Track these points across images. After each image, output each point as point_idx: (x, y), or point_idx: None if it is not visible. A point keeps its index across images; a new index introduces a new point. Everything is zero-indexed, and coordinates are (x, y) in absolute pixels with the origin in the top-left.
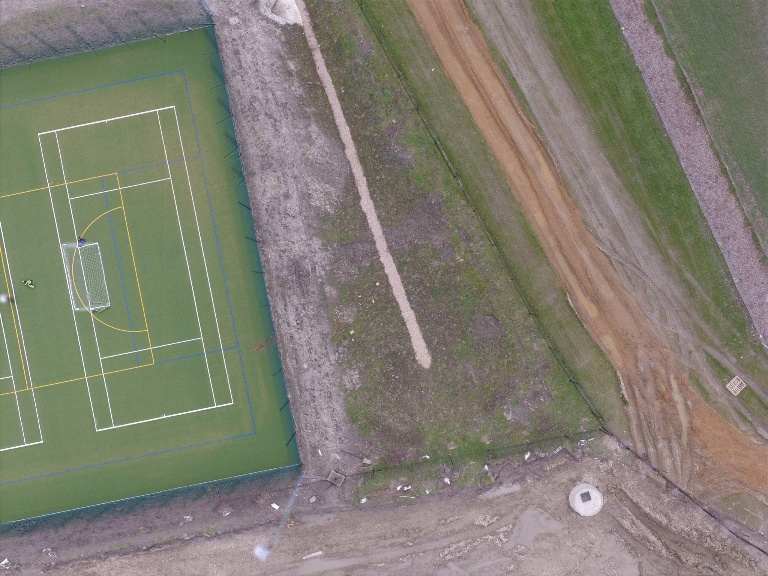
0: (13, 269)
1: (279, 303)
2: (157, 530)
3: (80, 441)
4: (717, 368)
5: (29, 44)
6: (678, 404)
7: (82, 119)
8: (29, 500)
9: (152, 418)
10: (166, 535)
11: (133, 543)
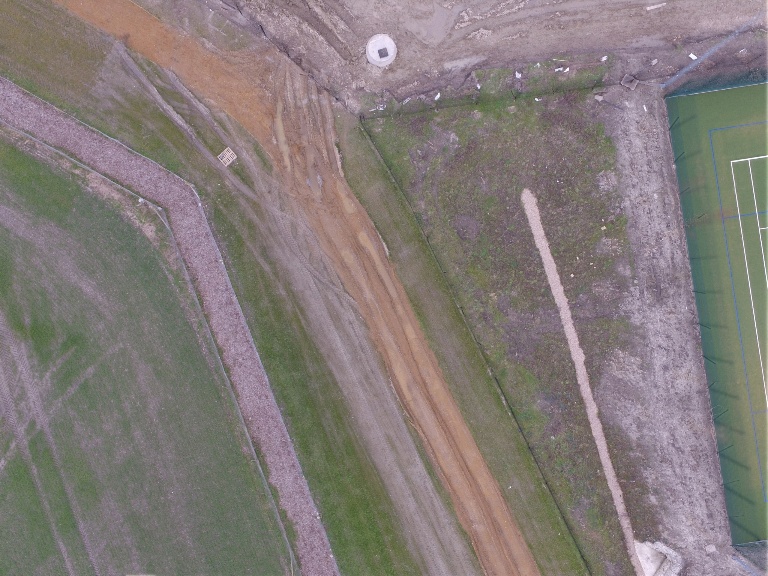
0: None
1: (679, 260)
2: None
3: None
4: (244, 175)
5: None
6: (284, 141)
7: None
8: None
9: None
10: None
11: None
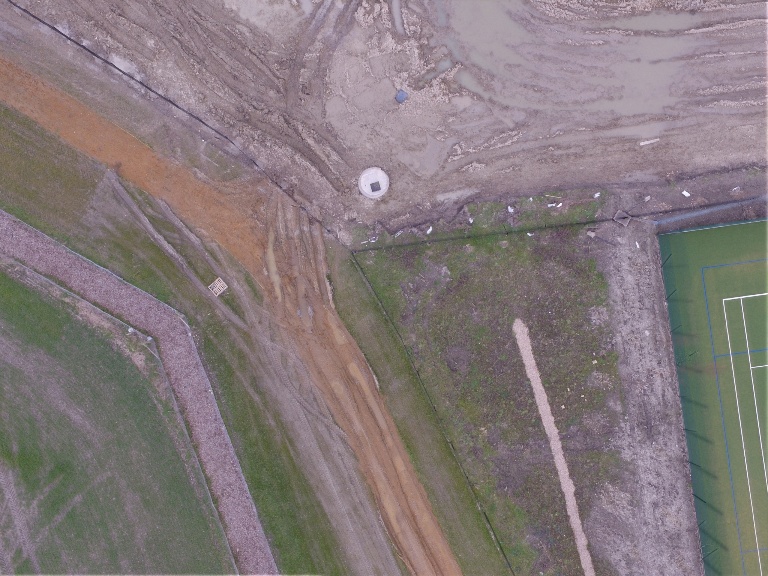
0: None
1: (670, 398)
2: None
3: None
4: (235, 305)
5: None
6: (275, 272)
7: None
8: None
9: None
10: None
11: None
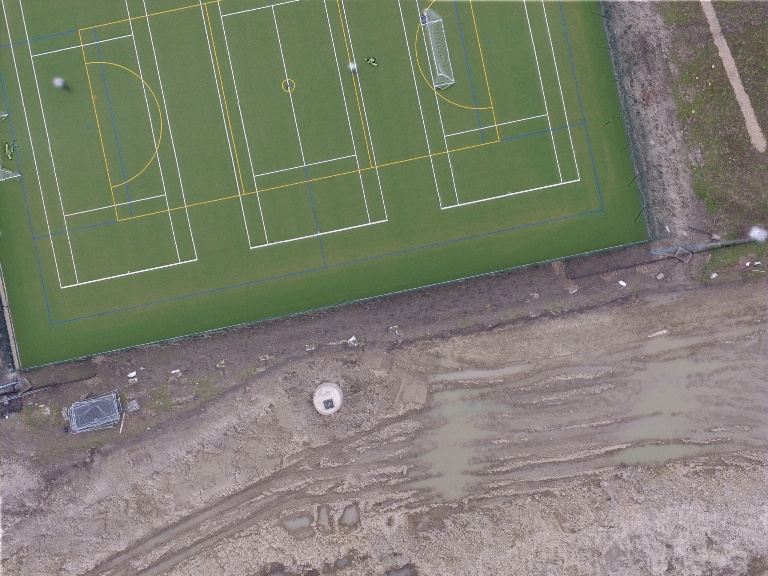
0: (356, 47)
1: (625, 79)
2: (503, 308)
3: (425, 219)
4: None
5: None
6: None
7: None
8: (374, 278)
9: (498, 195)
10: (512, 313)
11: (479, 321)
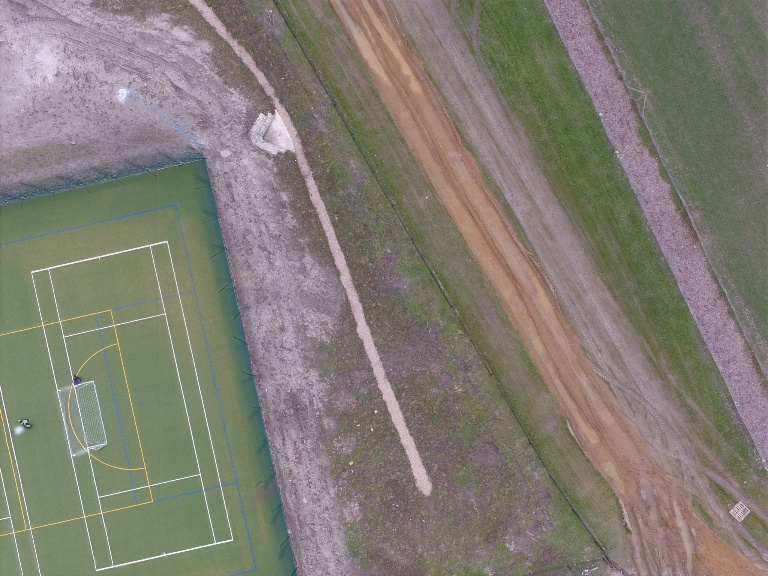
0: (9, 409)
1: (277, 438)
2: None
3: None
4: (720, 494)
5: (20, 182)
6: (682, 531)
7: (75, 256)
8: None
9: (152, 556)
10: None
11: None
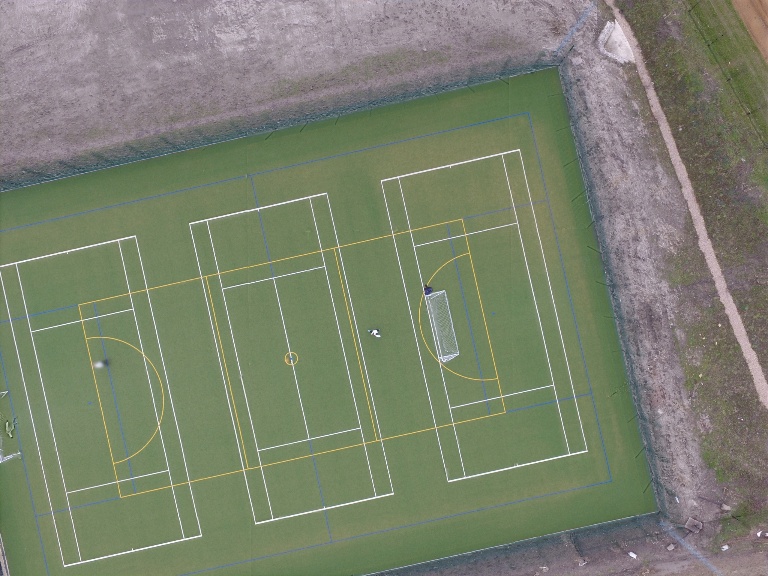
0: (359, 319)
1: (632, 348)
2: None
3: (432, 492)
4: None
5: (369, 89)
6: None
7: (425, 165)
8: (381, 553)
9: (505, 468)
10: None
11: None
